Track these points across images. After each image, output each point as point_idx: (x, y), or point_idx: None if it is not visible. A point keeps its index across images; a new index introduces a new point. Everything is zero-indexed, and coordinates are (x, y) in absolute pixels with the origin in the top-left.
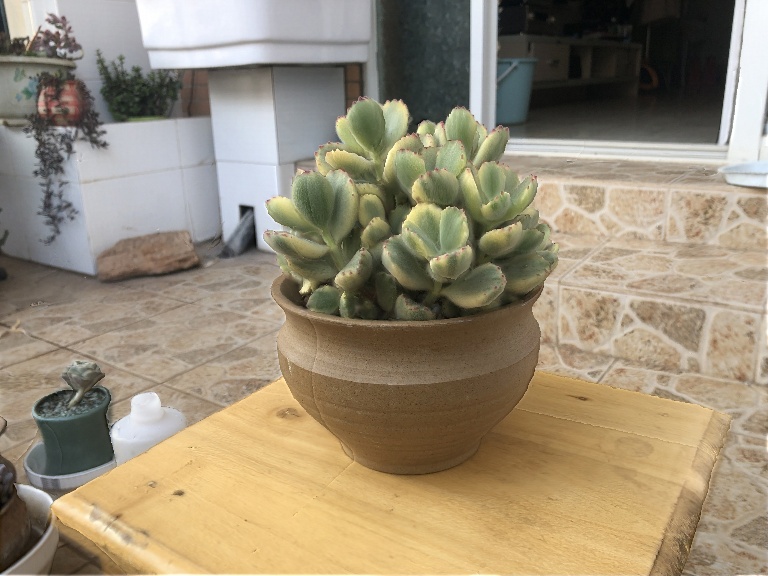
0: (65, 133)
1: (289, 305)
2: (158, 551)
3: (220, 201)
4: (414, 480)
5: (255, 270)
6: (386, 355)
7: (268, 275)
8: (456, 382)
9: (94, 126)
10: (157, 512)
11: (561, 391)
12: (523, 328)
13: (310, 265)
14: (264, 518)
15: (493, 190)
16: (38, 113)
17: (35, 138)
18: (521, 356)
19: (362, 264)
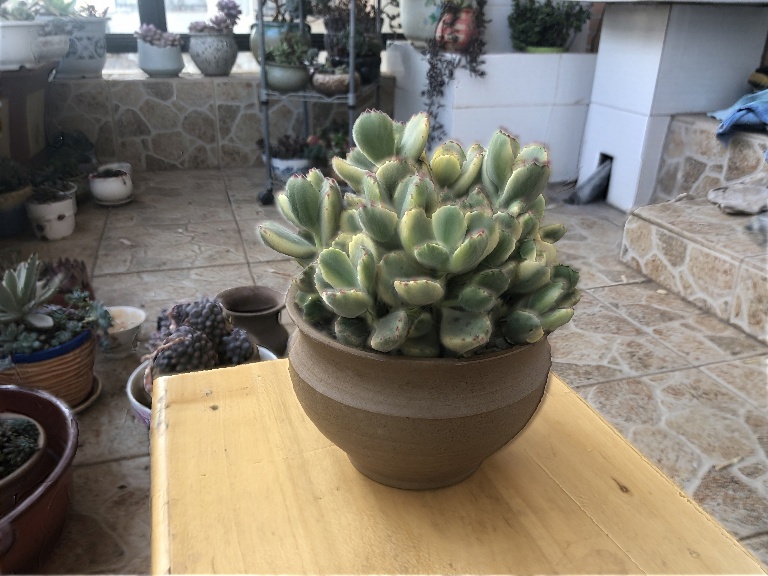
0: (450, 60)
1: (290, 290)
2: (163, 443)
3: (582, 145)
4: (366, 483)
5: (590, 223)
6: (323, 363)
7: (600, 232)
8: (368, 413)
9: (476, 56)
10: (189, 415)
11: (612, 470)
12: (477, 387)
13: (306, 261)
14: (236, 455)
15: (446, 237)
16: (435, 39)
17: (428, 62)
18: (458, 414)
19: (305, 276)
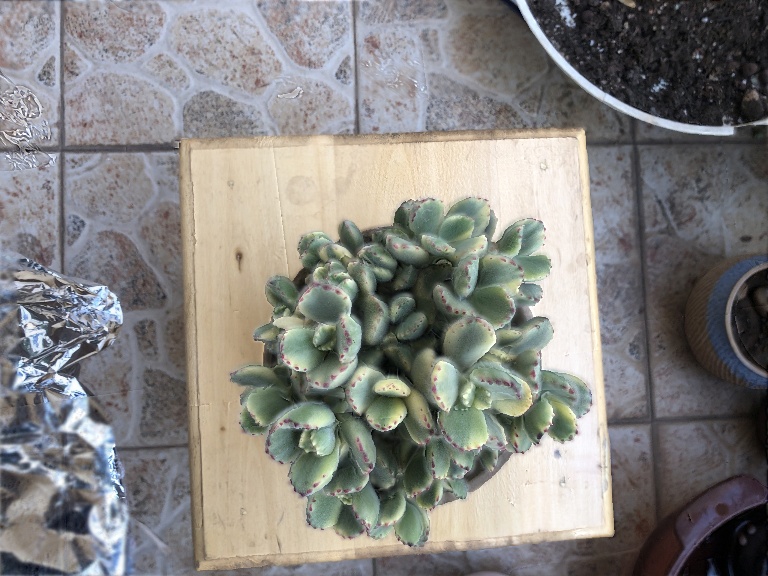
0: None
1: None
2: (600, 412)
3: None
4: None
5: None
6: None
7: None
8: None
9: None
10: (580, 447)
11: (235, 281)
12: None
13: None
14: None
15: None
16: None
17: None
18: None
19: None
